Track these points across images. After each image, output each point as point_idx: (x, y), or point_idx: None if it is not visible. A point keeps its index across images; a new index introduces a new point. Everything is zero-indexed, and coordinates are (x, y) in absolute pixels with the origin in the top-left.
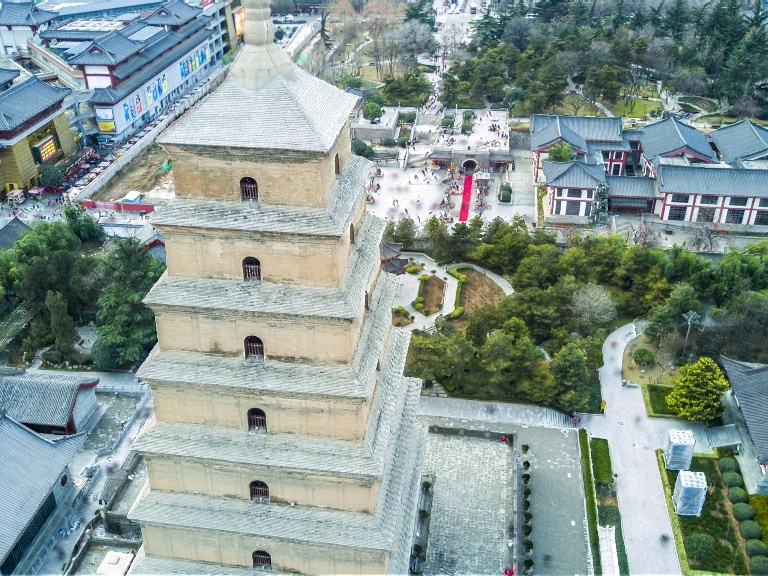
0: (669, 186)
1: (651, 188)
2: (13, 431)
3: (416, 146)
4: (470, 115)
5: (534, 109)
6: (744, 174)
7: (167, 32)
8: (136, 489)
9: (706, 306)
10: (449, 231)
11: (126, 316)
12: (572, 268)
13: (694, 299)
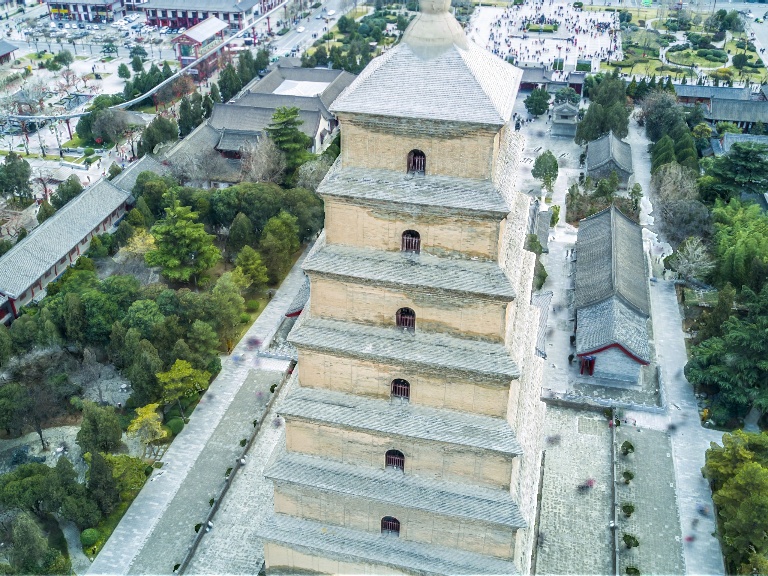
0: None
1: None
2: None
3: None
4: None
5: None
6: None
7: None
8: None
9: None
10: None
11: (727, 346)
12: None
13: None
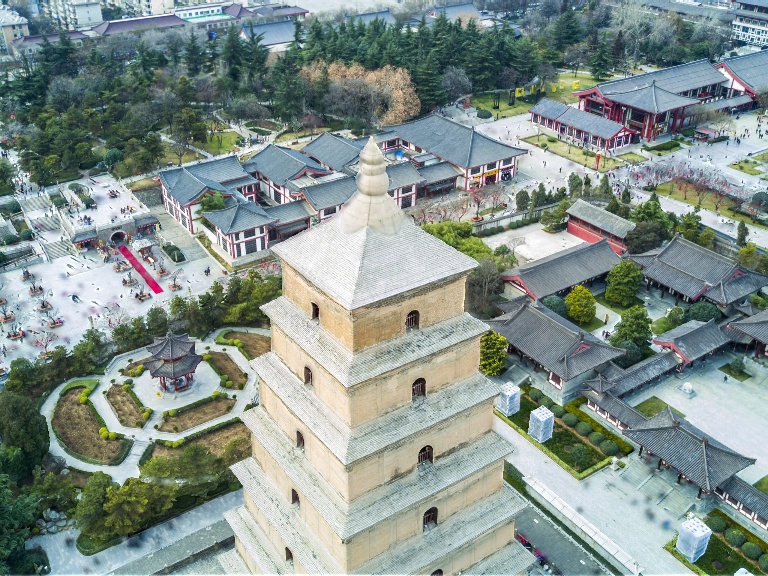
0: (320, 203)
1: (303, 209)
2: None
3: (42, 235)
4: (81, 188)
5: (143, 166)
6: None
7: None
8: None
9: None
10: (199, 305)
11: None
12: None
13: None
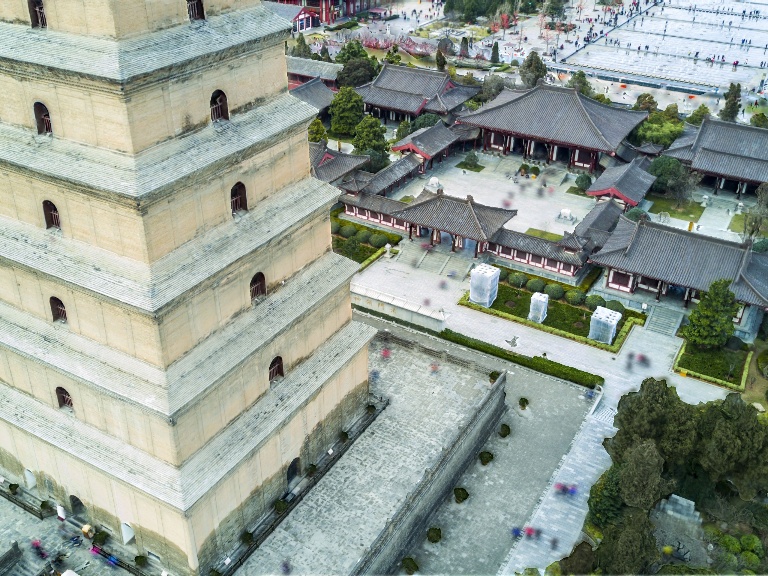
0: None
1: None
2: None
3: None
4: None
5: None
6: None
7: None
8: None
9: None
10: None
11: None
12: None
13: None
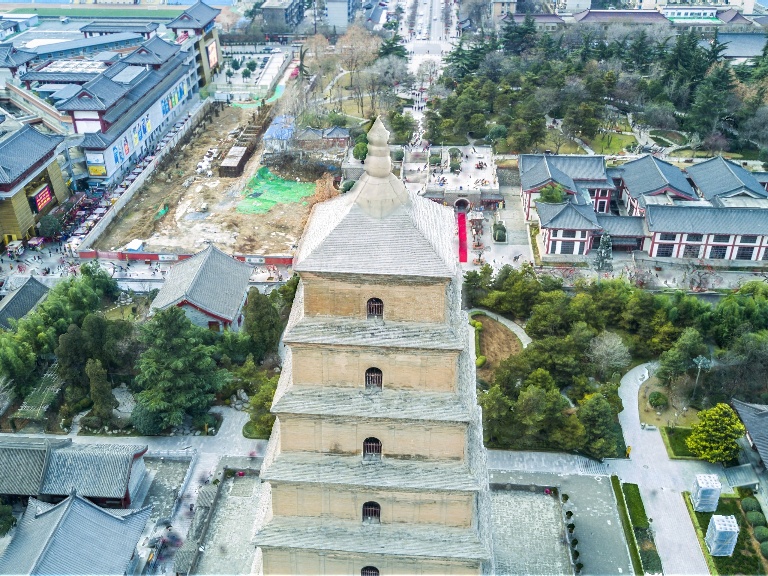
0: (658, 226)
1: (640, 227)
2: (85, 510)
3: (407, 185)
4: (457, 153)
5: (518, 147)
6: (726, 212)
7: (148, 71)
8: (208, 561)
9: (709, 347)
10: None
11: (168, 382)
12: (583, 314)
13: (701, 343)
